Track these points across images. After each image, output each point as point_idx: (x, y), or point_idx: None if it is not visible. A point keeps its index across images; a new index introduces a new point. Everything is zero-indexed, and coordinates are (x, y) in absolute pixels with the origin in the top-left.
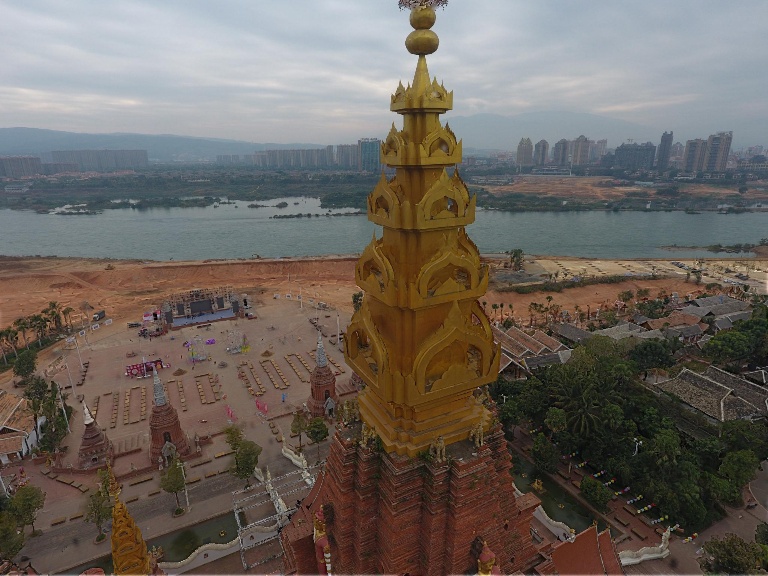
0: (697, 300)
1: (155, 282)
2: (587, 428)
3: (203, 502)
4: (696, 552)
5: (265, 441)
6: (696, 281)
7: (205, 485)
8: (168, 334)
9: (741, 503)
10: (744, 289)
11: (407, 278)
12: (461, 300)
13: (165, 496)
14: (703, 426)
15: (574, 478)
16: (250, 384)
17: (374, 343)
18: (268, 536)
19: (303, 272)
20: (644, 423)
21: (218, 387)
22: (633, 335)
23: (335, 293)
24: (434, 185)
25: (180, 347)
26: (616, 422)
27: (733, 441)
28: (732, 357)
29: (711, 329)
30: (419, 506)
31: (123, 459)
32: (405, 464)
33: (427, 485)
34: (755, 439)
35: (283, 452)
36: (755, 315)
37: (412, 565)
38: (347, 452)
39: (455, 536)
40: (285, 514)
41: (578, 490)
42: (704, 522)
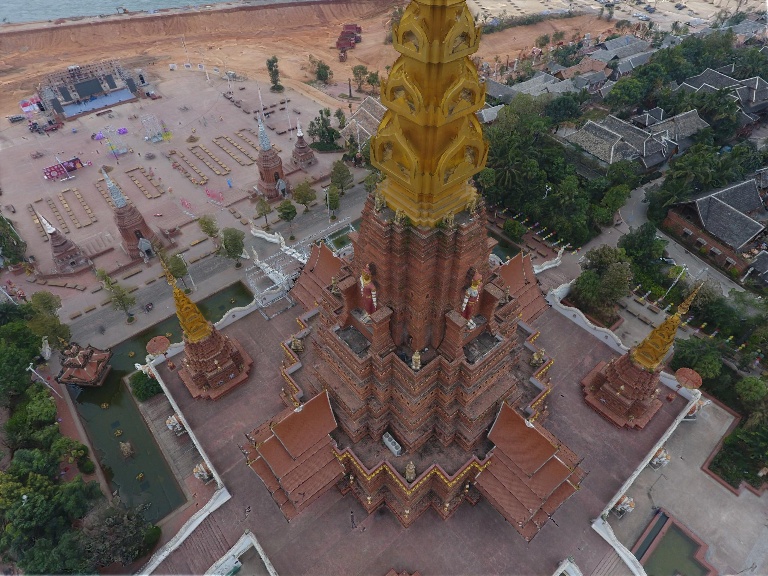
0: (606, 42)
1: (4, 57)
2: (510, 181)
3: (205, 281)
4: (579, 259)
5: (231, 226)
6: (608, 17)
7: (195, 269)
8: (65, 126)
9: (612, 223)
10: (649, 26)
11: (428, 100)
12: (468, 114)
13: (163, 282)
14: (596, 169)
15: (498, 221)
16: (189, 173)
17: (407, 153)
18: (276, 296)
19: (191, 30)
20: (552, 171)
21: (157, 180)
22: (548, 87)
23: (240, 58)
24: (456, 23)
25: (89, 141)
26: (532, 174)
27: (615, 178)
28: (627, 104)
29: (614, 74)
30: (436, 255)
31: (100, 259)
32: (428, 232)
33: (441, 242)
34: (631, 175)
35: (253, 233)
36: (653, 59)
37: (431, 289)
38: (386, 229)
39: (459, 269)
40: (290, 279)
41: (501, 230)
42: (586, 239)
